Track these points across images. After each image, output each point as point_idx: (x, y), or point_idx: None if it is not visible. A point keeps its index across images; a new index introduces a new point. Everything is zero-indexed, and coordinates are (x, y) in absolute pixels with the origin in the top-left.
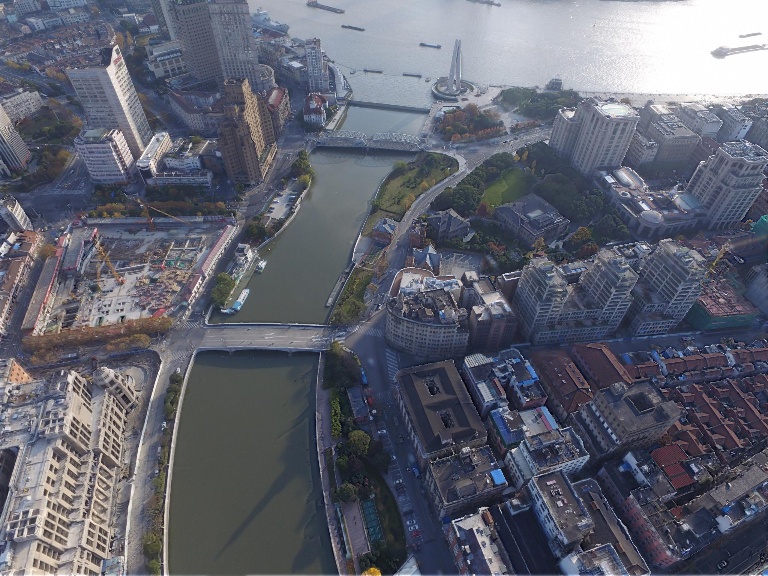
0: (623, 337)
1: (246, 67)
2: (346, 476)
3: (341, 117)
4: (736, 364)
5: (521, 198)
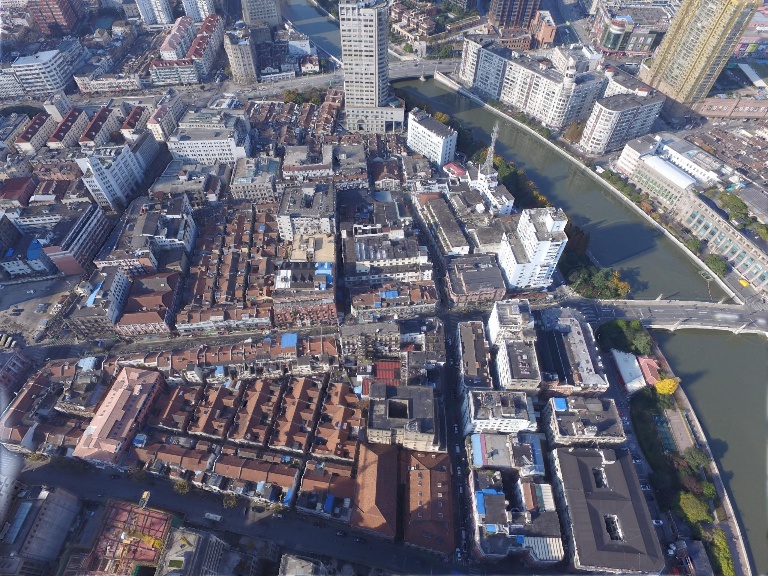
0: None
1: None
2: (699, 477)
3: None
4: None
5: None
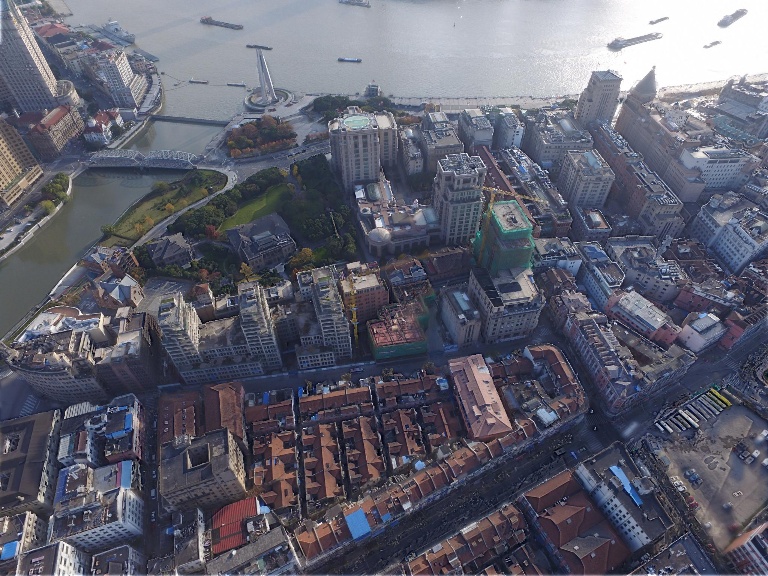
0: (292, 371)
1: (33, 85)
2: None
3: (133, 134)
4: (381, 399)
5: (259, 218)
